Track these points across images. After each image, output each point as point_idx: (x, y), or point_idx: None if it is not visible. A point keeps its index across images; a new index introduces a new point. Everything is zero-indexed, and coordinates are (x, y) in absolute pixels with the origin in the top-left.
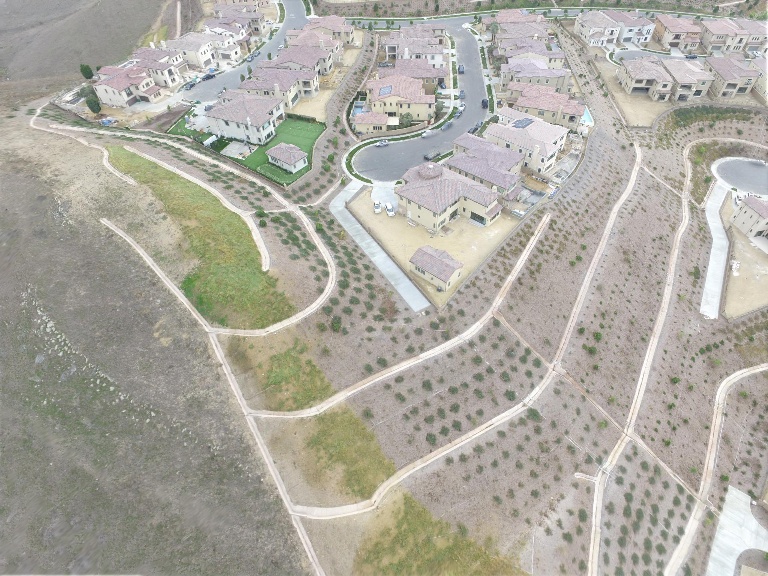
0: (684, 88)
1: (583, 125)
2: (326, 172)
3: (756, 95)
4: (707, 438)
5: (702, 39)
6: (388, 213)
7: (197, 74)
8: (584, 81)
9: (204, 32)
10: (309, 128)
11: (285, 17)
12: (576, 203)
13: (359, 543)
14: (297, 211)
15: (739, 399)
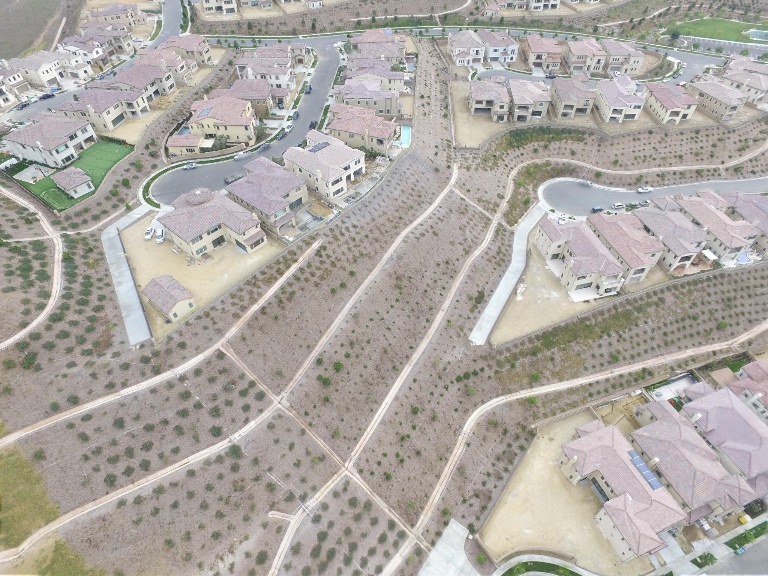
0: (523, 109)
1: (398, 147)
2: (113, 197)
3: (595, 116)
4: (441, 469)
5: (567, 59)
6: (156, 240)
7: (37, 93)
8: (425, 102)
9: (58, 50)
10: (117, 151)
11: (159, 35)
12: (357, 228)
13: None
14: (58, 239)
15: (488, 428)
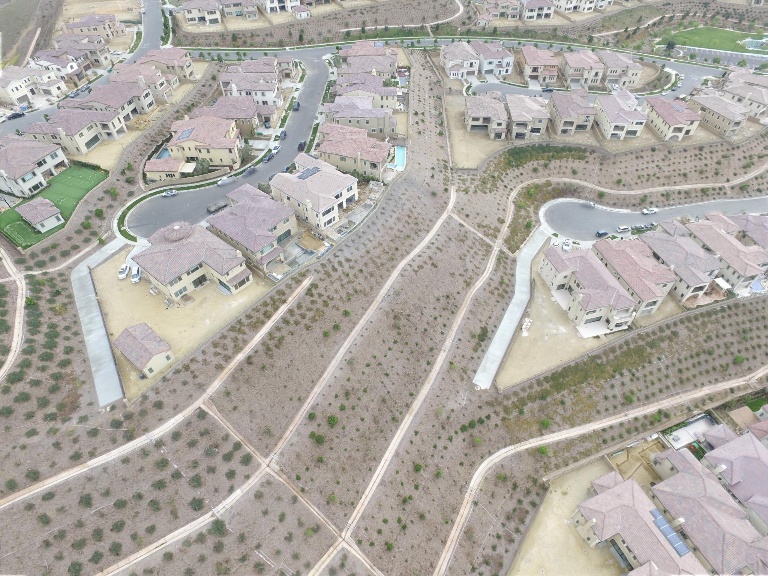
0: (521, 126)
1: (392, 170)
2: (85, 230)
3: (595, 132)
4: (447, 534)
5: (564, 71)
6: (131, 279)
7: (6, 112)
8: (419, 119)
9: (29, 65)
10: (90, 177)
11: (138, 47)
12: (350, 262)
13: None
14: (21, 280)
15: (497, 483)
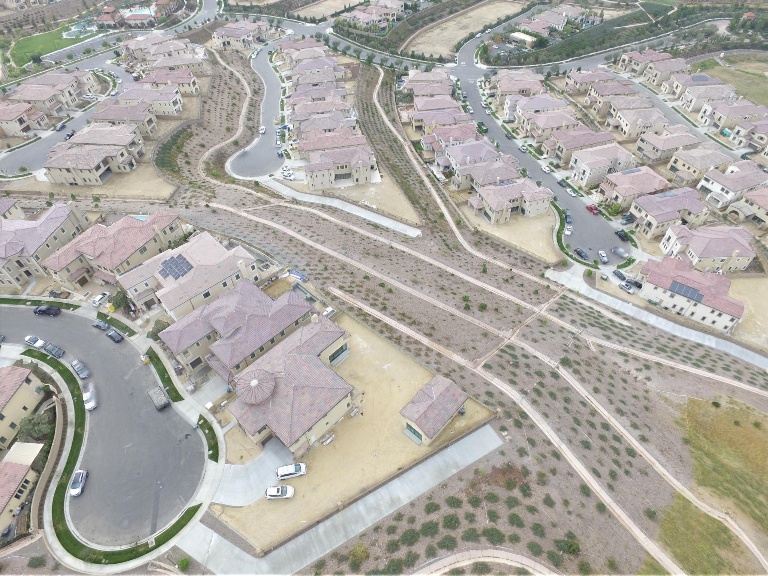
0: None
1: None
2: None
3: (165, 118)
4: (516, 273)
5: None
6: (301, 473)
7: None
8: None
9: None
10: None
11: None
12: (310, 265)
13: (765, 537)
14: None
15: (479, 248)
